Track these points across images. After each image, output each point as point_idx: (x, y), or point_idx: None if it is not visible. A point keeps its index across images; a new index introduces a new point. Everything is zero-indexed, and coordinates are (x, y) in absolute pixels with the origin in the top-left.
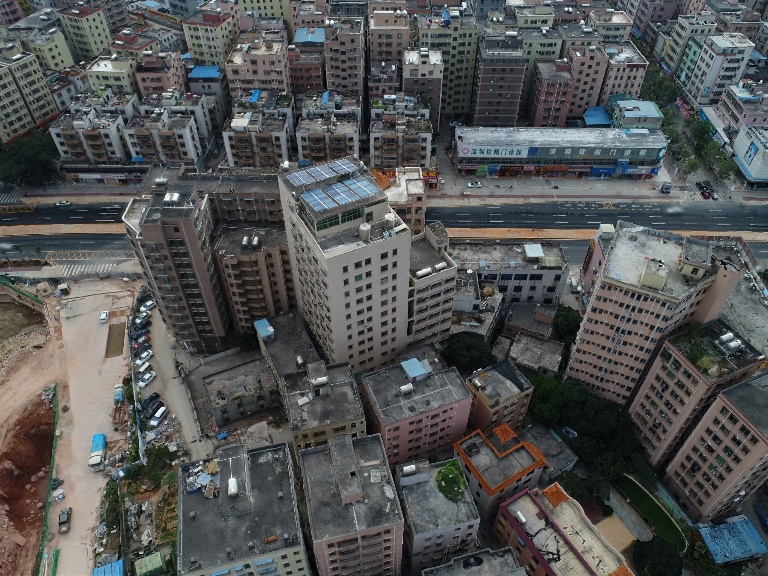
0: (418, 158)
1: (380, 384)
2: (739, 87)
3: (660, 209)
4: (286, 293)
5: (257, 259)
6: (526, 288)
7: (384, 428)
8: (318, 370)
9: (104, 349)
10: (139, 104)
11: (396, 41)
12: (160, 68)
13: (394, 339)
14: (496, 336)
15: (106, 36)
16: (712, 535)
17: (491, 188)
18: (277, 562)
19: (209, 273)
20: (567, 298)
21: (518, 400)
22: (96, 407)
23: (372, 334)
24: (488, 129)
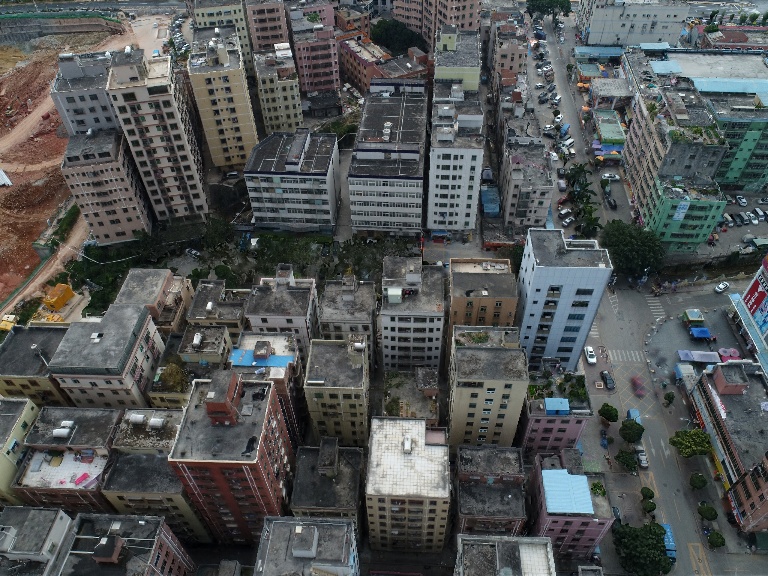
0: None
1: (291, 3)
2: None
3: None
4: None
5: None
6: (388, 2)
7: None
8: None
9: (156, 35)
10: None
11: None
12: None
13: None
14: None
15: None
16: None
17: None
18: (232, 15)
19: None
20: None
21: (361, 19)
22: (154, 49)
23: None
24: None
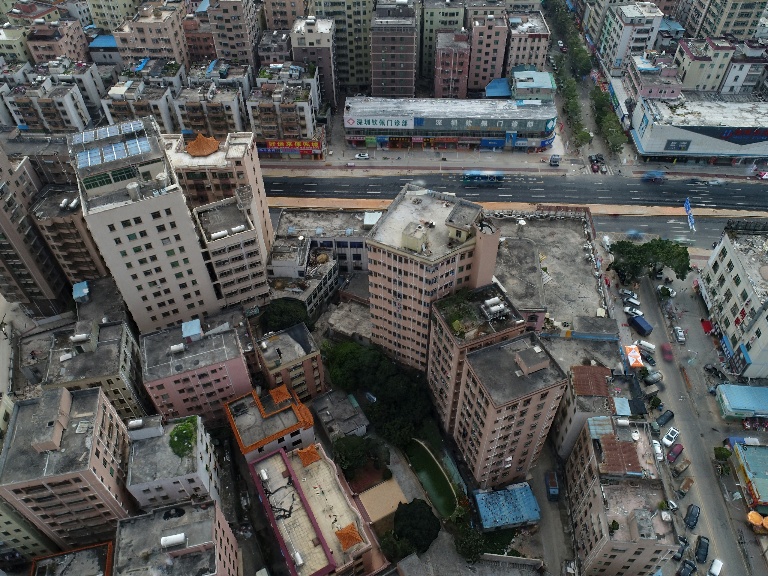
0: (299, 128)
1: (156, 344)
2: (643, 58)
3: (544, 182)
4: None
5: (73, 221)
6: (365, 256)
7: (144, 385)
8: (85, 327)
9: None
10: (29, 72)
11: (290, 10)
12: (53, 36)
13: (202, 302)
14: (336, 304)
15: None
16: (487, 501)
17: (378, 159)
18: None
19: (22, 234)
20: None
21: (304, 363)
22: None
23: (172, 296)
24: (378, 100)
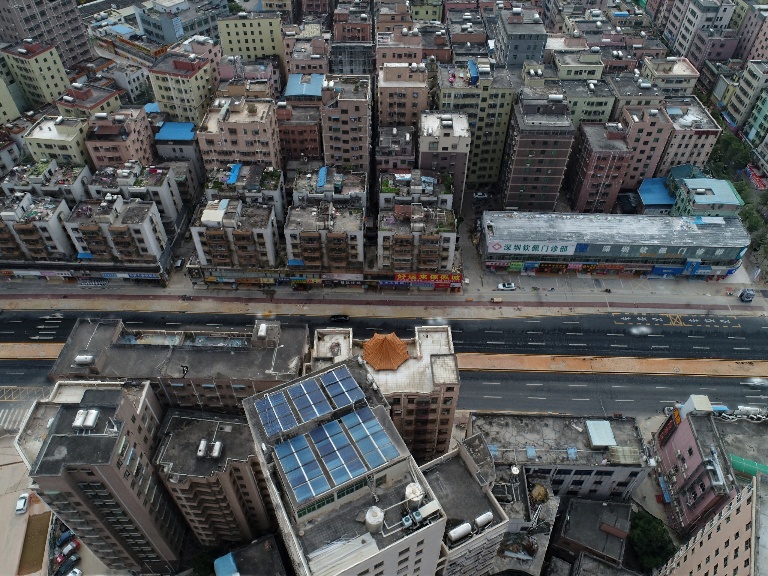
0: (438, 259)
1: None
2: None
3: (741, 326)
4: (262, 502)
5: (218, 478)
6: (589, 482)
7: None
8: None
9: (16, 561)
10: (89, 181)
11: (411, 101)
12: (117, 133)
13: None
14: None
15: (61, 78)
16: None
17: (527, 291)
18: None
19: (148, 505)
20: None
21: None
22: None
23: None
24: (524, 215)
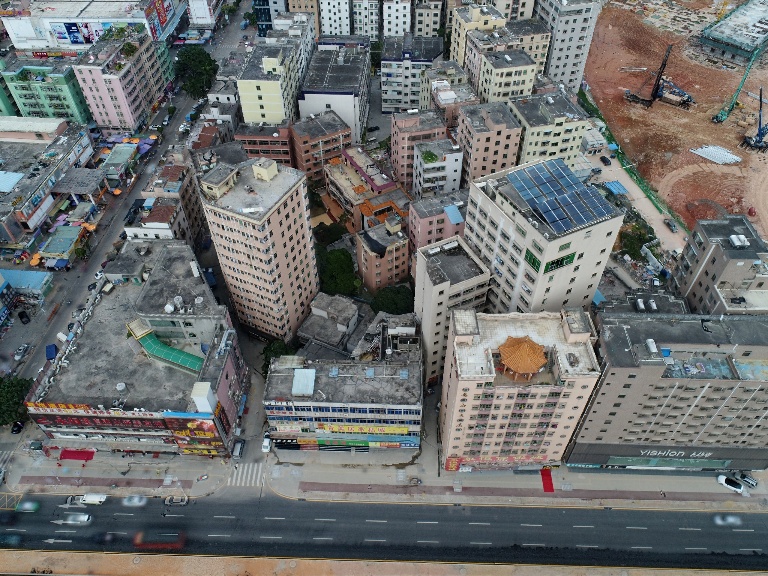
0: None
1: None
2: None
3: None
4: None
5: None
6: None
7: None
8: None
9: None
10: None
11: None
12: None
13: None
14: None
15: None
16: None
17: None
18: None
19: None
20: (255, 433)
21: None
22: None
23: None
24: None
